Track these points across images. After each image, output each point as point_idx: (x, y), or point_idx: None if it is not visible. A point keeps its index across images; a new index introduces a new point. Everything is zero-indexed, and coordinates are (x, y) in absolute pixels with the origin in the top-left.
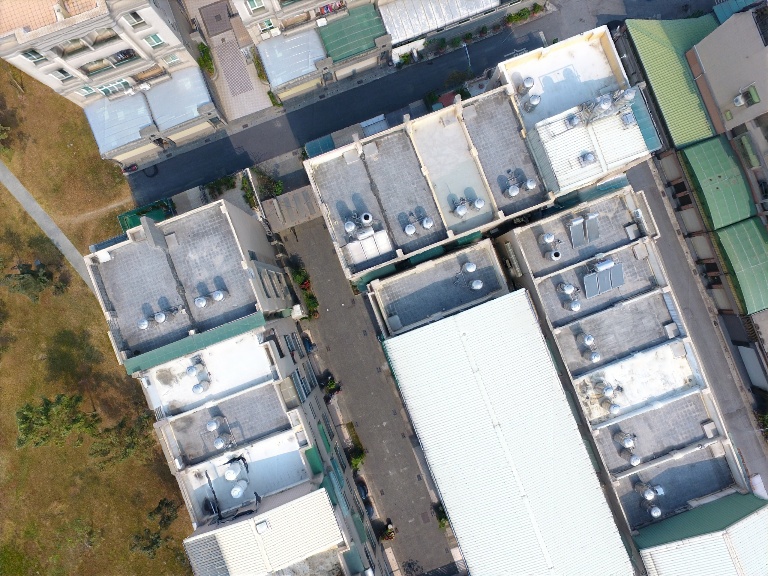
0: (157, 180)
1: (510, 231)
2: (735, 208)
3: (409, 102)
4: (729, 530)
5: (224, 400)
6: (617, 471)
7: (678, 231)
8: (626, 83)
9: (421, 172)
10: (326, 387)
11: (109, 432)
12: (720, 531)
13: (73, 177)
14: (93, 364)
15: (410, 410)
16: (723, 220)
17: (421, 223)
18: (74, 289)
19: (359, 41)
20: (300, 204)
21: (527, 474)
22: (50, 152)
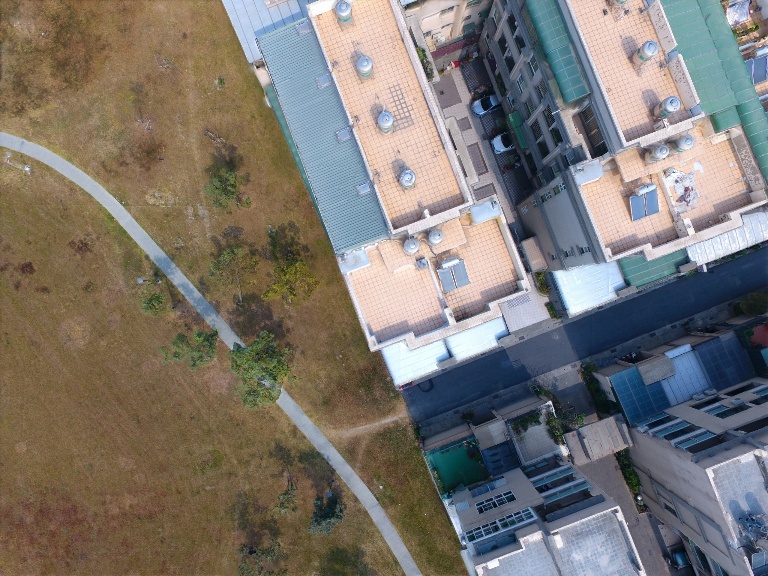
0: (433, 395)
1: None
2: None
3: (690, 312)
4: None
5: None
6: None
7: None
8: None
9: None
10: None
11: None
12: None
13: (344, 390)
14: None
15: None
16: None
17: None
18: None
19: (661, 267)
20: (604, 437)
21: None
22: (319, 364)
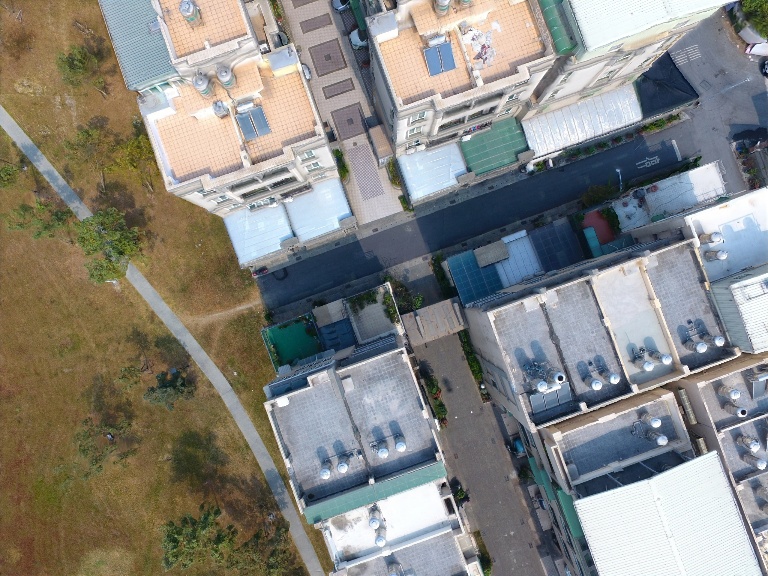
0: (286, 283)
1: (689, 382)
2: None
3: (540, 209)
4: None
5: (400, 548)
6: None
7: None
8: None
9: (601, 321)
10: (456, 497)
11: (248, 546)
12: None
13: (201, 277)
14: (218, 466)
15: (600, 572)
16: None
17: (602, 374)
18: (200, 390)
19: (501, 155)
20: (440, 319)
21: None
22: (178, 252)
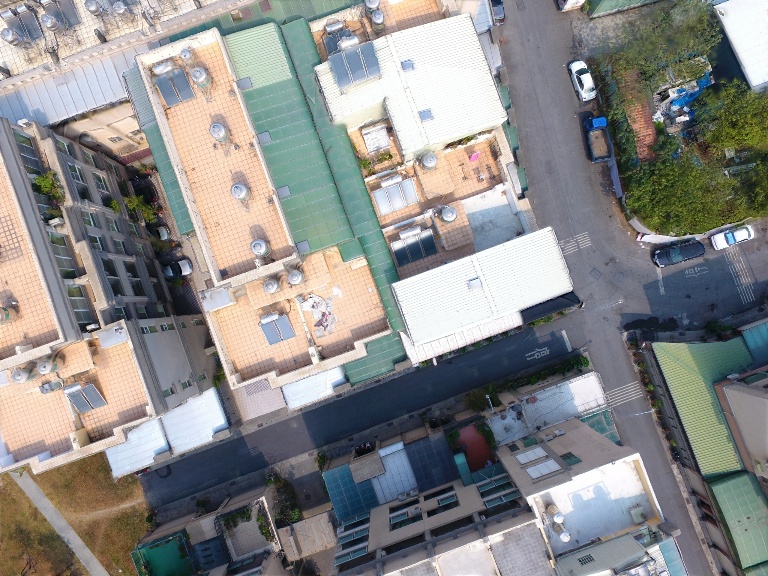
0: (170, 481)
1: None
2: (764, 549)
3: (428, 402)
4: None
5: None
6: None
7: (703, 540)
8: (659, 514)
9: None
10: None
11: None
12: None
13: (84, 474)
14: None
15: None
16: (751, 561)
17: None
18: None
19: (378, 364)
20: (317, 533)
21: None
22: None
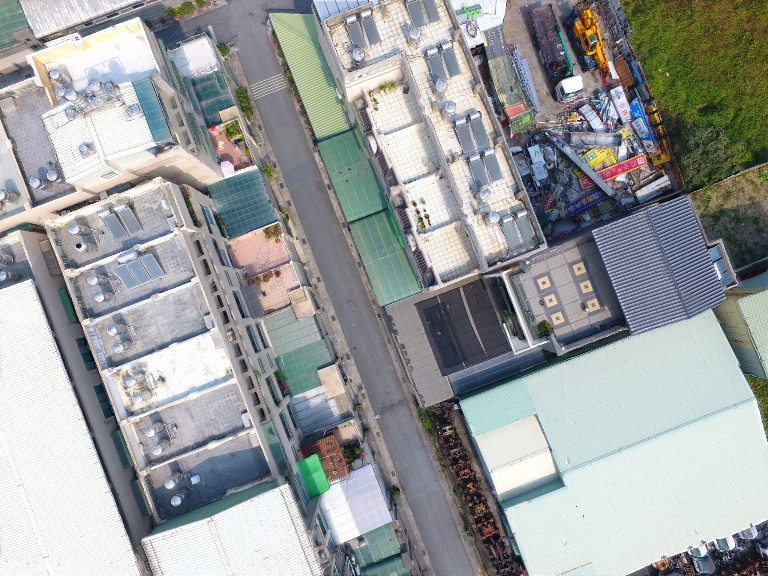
0: None
1: None
2: (366, 200)
3: None
4: (215, 518)
5: None
6: (158, 461)
7: (343, 224)
8: None
9: None
10: None
11: None
12: (205, 519)
13: None
14: None
15: None
16: (355, 212)
17: None
18: None
19: (0, 35)
20: None
21: (25, 464)
22: None
